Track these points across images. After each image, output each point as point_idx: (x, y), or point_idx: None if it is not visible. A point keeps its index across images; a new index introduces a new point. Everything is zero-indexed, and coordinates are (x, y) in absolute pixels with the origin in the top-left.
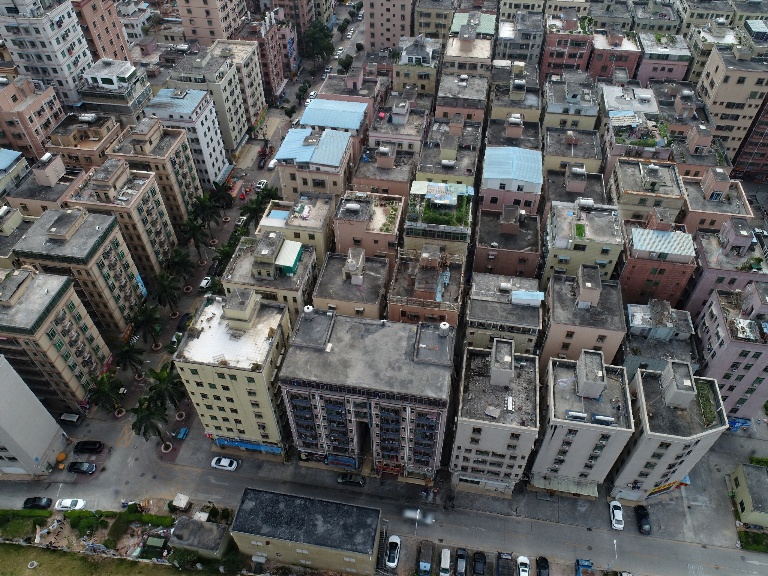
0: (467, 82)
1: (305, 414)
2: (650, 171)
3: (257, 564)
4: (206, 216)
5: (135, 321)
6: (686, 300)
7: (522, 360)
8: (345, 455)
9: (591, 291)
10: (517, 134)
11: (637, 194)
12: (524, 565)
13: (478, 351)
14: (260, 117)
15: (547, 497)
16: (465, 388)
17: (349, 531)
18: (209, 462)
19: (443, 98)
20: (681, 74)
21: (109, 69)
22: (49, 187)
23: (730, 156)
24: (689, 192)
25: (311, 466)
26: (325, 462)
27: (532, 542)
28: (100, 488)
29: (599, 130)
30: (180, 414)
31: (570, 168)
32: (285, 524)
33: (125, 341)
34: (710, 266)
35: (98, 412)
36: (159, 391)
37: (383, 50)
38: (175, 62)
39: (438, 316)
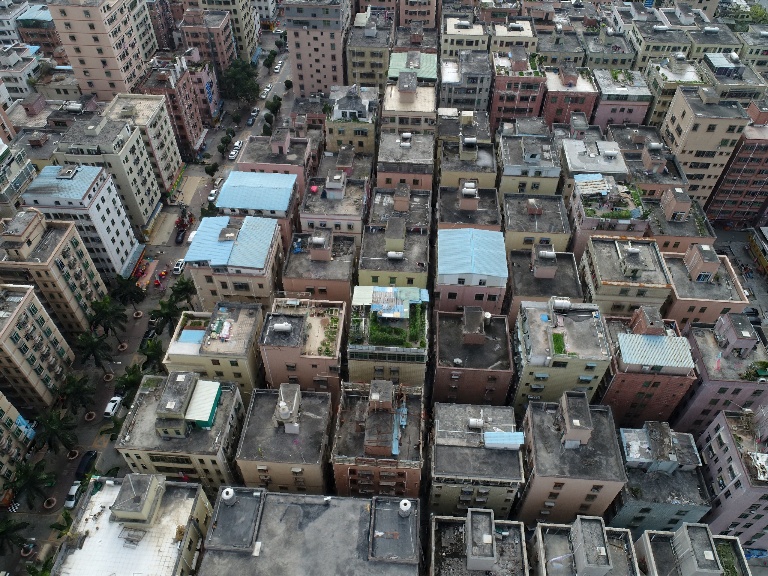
0: (411, 141)
1: None
2: (630, 255)
3: None
4: (108, 324)
5: (14, 486)
6: (682, 408)
7: (504, 528)
8: None
9: (580, 430)
10: (472, 206)
11: (618, 285)
12: None
13: (449, 520)
14: (176, 179)
15: None
16: None
17: None
18: None
19: (384, 163)
20: (641, 115)
21: None
22: None
23: None
24: (673, 272)
25: None
26: None
27: None
28: None
29: (562, 191)
30: None
31: (537, 249)
32: None
33: (8, 500)
34: (710, 374)
35: None
36: None
37: (313, 95)
38: (66, 125)
39: (396, 473)
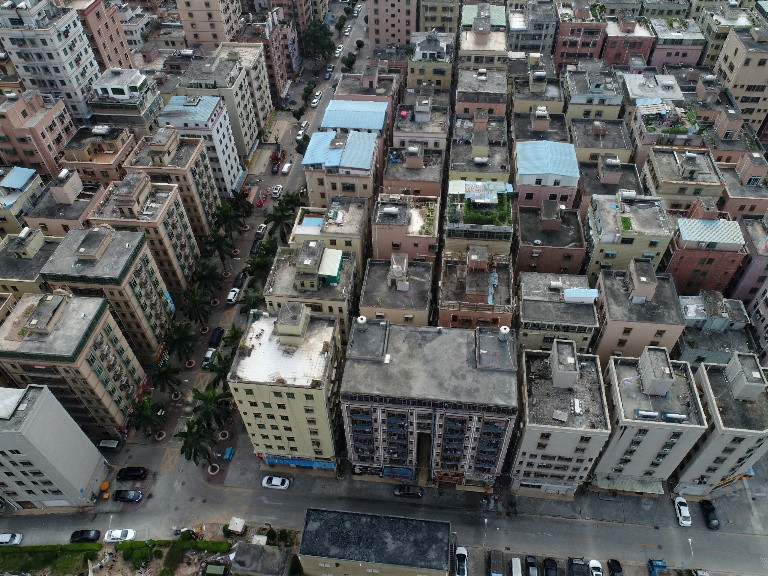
0: (486, 76)
1: (365, 428)
2: (687, 159)
3: None
4: (229, 226)
5: (169, 340)
6: (733, 288)
7: (582, 360)
8: (402, 467)
9: (647, 285)
10: (544, 127)
11: (677, 183)
12: (597, 569)
13: (536, 353)
14: (268, 121)
15: (610, 497)
16: (528, 392)
17: (421, 547)
18: (259, 482)
19: (464, 93)
20: (695, 58)
21: (119, 79)
22: (68, 205)
23: None
24: (725, 178)
25: (365, 480)
26: (380, 475)
27: (601, 545)
28: (149, 516)
29: (623, 119)
30: (223, 433)
31: (603, 159)
32: (354, 544)
33: (157, 360)
34: (759, 253)
35: (137, 436)
36: (204, 412)
37: (390, 46)
38: (180, 68)
39: (491, 319)
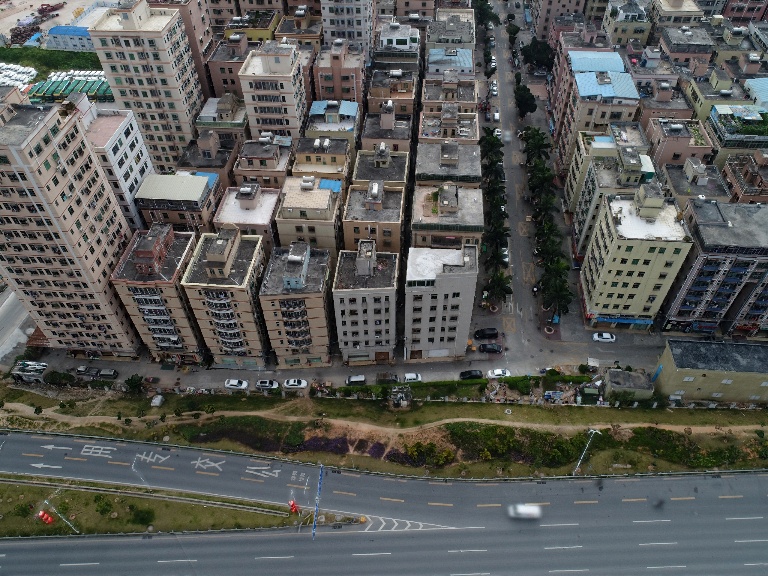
0: None
1: (706, 280)
2: None
3: (678, 400)
4: (497, 154)
5: (493, 234)
6: None
7: None
8: (709, 321)
9: None
10: (755, 70)
11: None
12: None
13: None
14: None
15: None
16: None
17: (765, 362)
18: (589, 338)
19: (678, 45)
20: None
21: (399, 32)
22: (390, 130)
23: None
24: None
25: (673, 335)
26: (685, 330)
27: None
28: (513, 362)
29: None
30: None
31: None
32: (714, 361)
33: None
34: None
35: (474, 310)
36: (548, 282)
37: (568, 14)
38: None
39: None
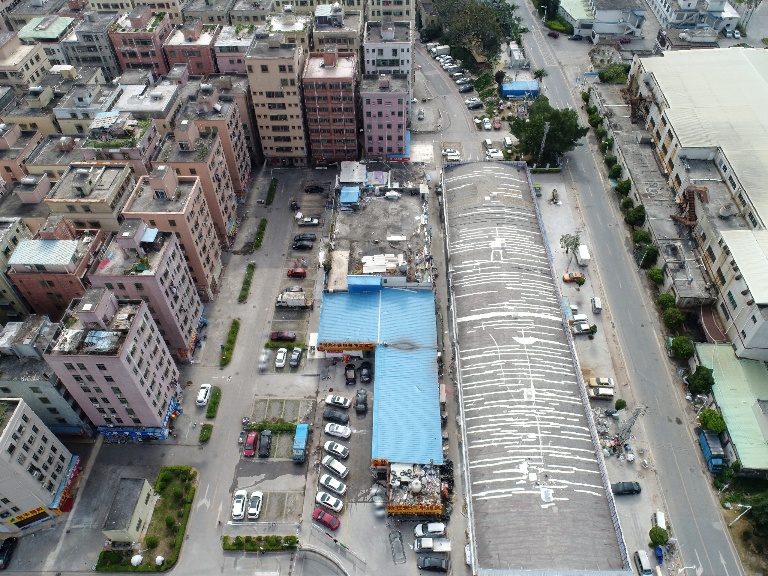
0: None
1: None
2: (80, 175)
3: None
4: None
5: None
6: None
7: None
8: None
9: None
10: (4, 145)
11: (57, 202)
12: None
13: None
14: None
15: None
16: None
17: None
18: None
19: None
20: None
21: None
22: None
23: (301, 145)
24: (144, 192)
25: None
26: None
27: None
28: None
29: None
30: None
31: None
32: None
33: None
34: (99, 272)
35: None
36: None
37: None
38: None
39: None
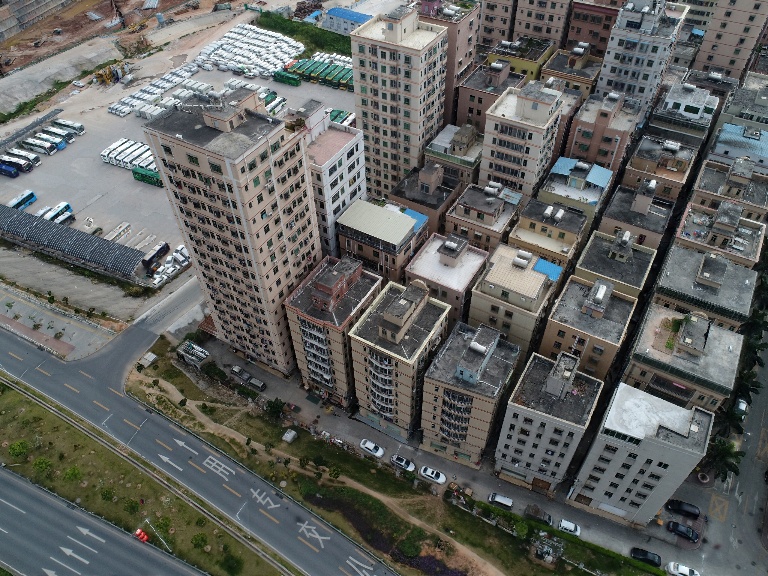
0: None
1: None
2: None
3: None
4: None
5: (735, 384)
6: None
7: None
8: None
9: None
10: None
11: None
12: None
13: None
14: None
15: None
16: None
17: None
18: None
19: None
20: None
21: (693, 96)
22: (642, 214)
23: None
24: None
25: None
26: None
27: None
28: (709, 563)
29: None
30: None
31: None
32: None
33: None
34: None
35: None
36: None
37: None
38: None
39: None
